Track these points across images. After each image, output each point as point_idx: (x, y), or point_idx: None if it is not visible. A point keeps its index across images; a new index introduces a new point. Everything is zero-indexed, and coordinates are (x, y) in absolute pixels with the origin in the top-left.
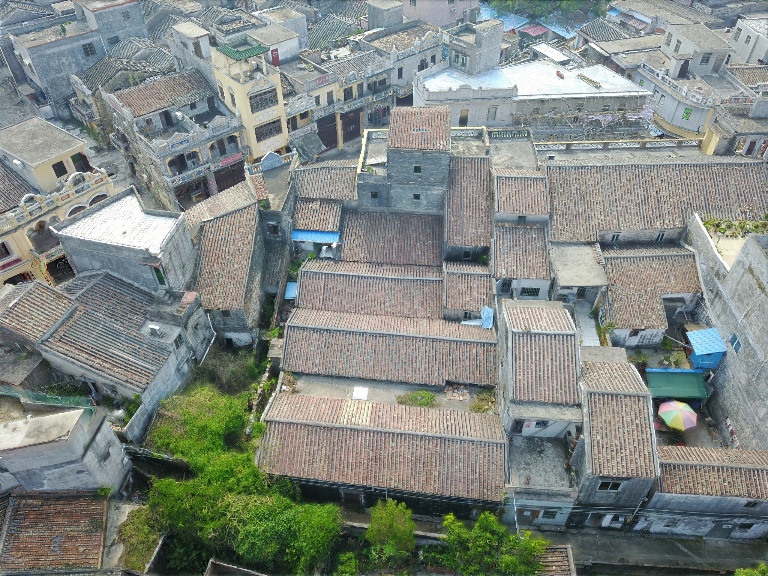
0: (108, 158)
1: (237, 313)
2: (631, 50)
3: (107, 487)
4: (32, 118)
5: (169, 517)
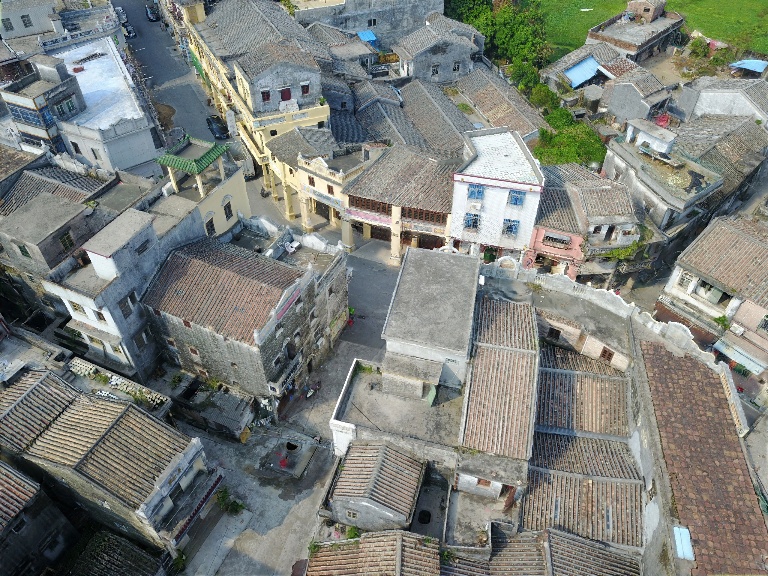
0: (247, 484)
1: None
2: (8, 49)
3: None
4: (389, 336)
5: None
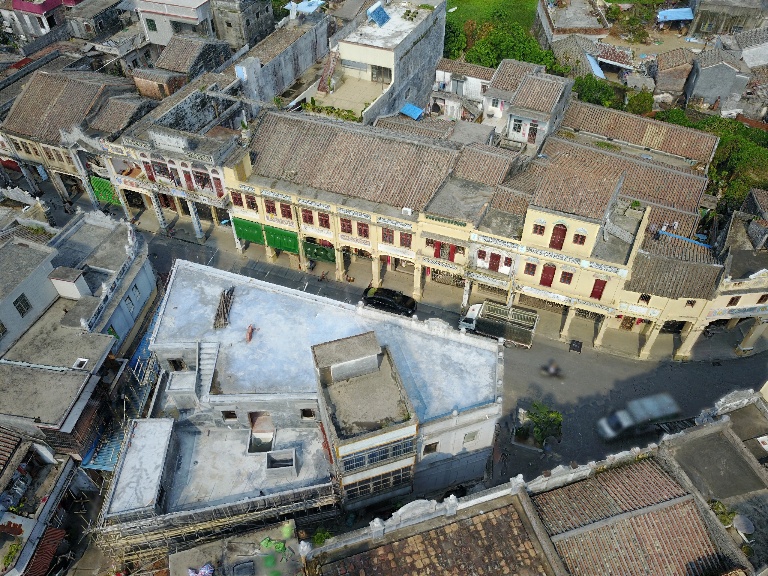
0: None
1: None
2: (47, 370)
3: None
4: None
5: None
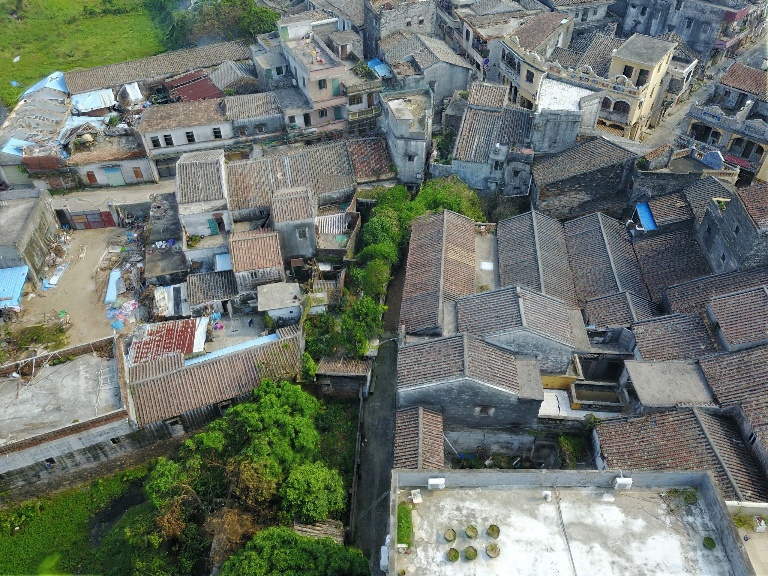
0: None
1: (536, 188)
2: None
3: (400, 172)
4: (673, 42)
5: (383, 195)
